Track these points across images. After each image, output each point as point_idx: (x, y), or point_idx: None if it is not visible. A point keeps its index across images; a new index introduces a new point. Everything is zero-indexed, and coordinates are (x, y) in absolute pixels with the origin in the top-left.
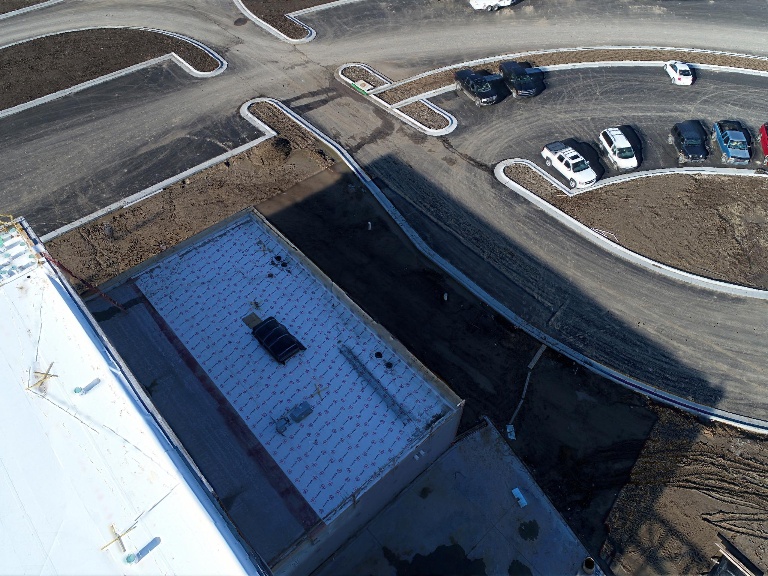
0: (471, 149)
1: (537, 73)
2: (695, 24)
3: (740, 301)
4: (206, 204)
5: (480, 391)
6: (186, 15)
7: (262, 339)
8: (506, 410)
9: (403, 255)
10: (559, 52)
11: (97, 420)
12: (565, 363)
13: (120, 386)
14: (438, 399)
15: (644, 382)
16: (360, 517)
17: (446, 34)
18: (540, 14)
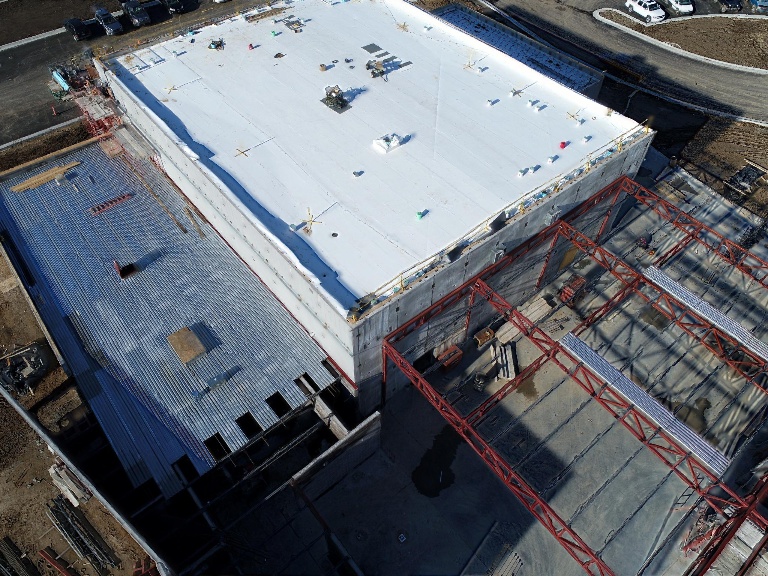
0: (575, 3)
1: None
2: None
3: (762, 76)
4: None
5: None
6: None
7: None
8: None
9: None
10: None
11: (439, 38)
12: (651, 96)
13: (447, 25)
14: (588, 78)
15: (701, 106)
16: None
17: None
18: None
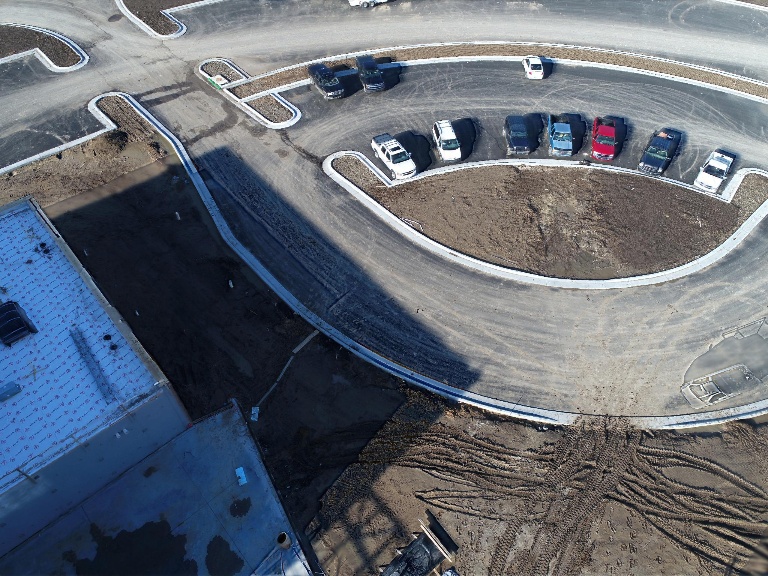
0: (307, 142)
1: (395, 68)
2: (567, 20)
3: (525, 288)
4: (24, 195)
5: (238, 375)
6: (62, 11)
7: None
8: (257, 393)
9: (205, 244)
10: (423, 47)
11: None
12: (331, 348)
13: None
14: (151, 379)
15: (404, 366)
16: (61, 494)
17: (316, 30)
18: (416, 10)
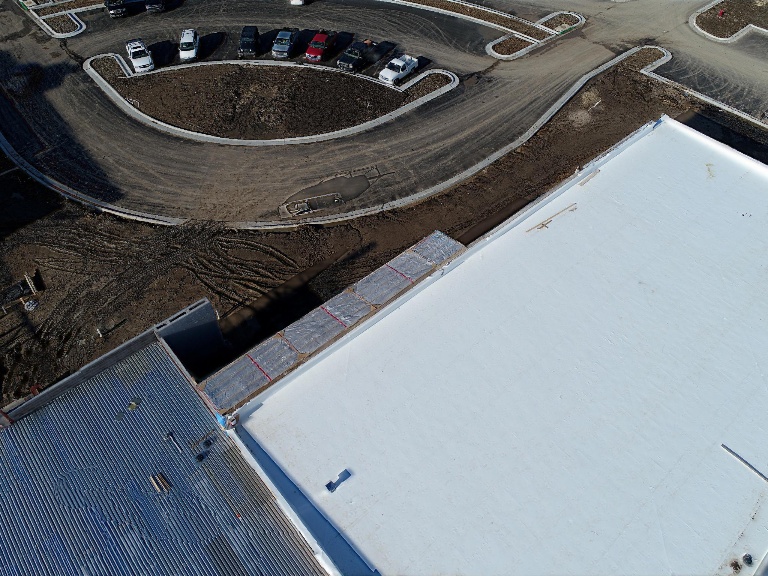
0: (80, 47)
1: None
2: None
3: (199, 144)
4: None
5: None
6: None
7: None
8: None
9: None
10: None
11: None
12: (21, 177)
13: None
14: None
15: (74, 189)
16: None
17: None
18: None
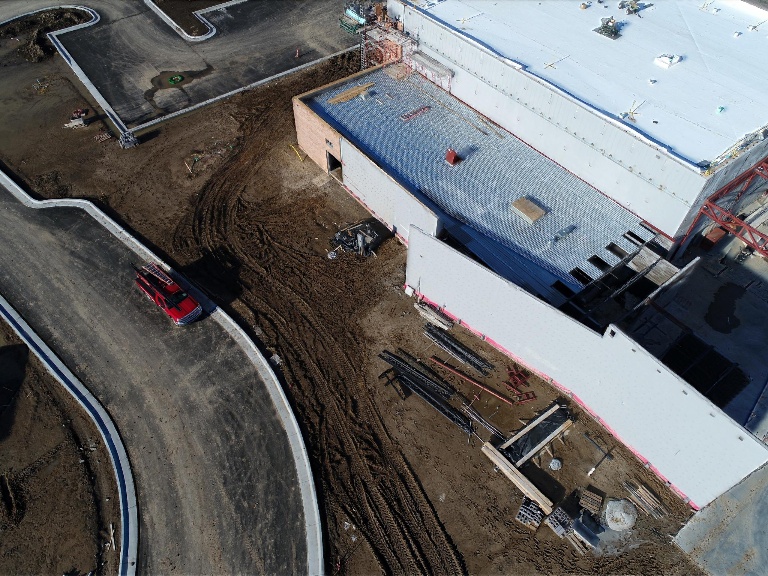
0: None
1: None
2: None
3: None
4: None
5: None
6: None
7: None
8: None
9: None
10: None
11: None
12: None
13: None
14: None
15: None
16: None
17: None
18: None
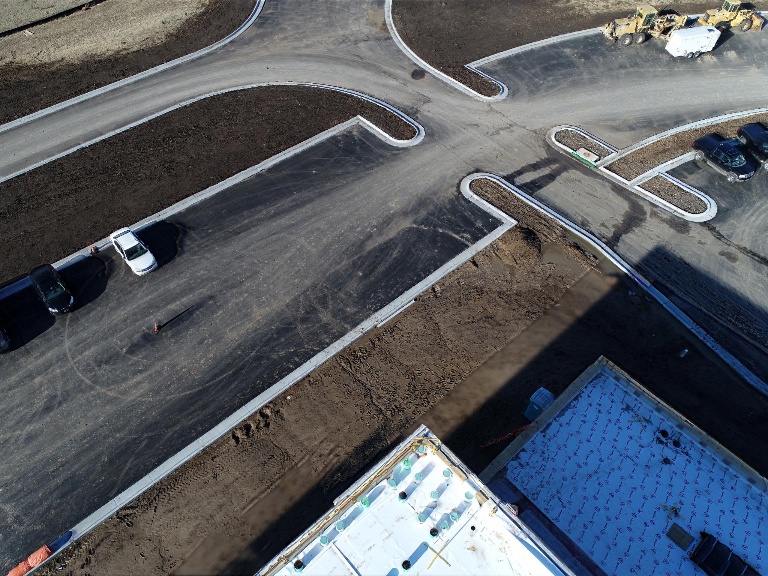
0: (747, 240)
1: None
2: None
3: None
4: (474, 322)
5: None
6: (355, 67)
7: (718, 574)
8: None
9: (737, 393)
10: None
11: None
12: None
13: None
14: None
15: None
16: None
17: (653, 88)
18: (747, 61)
